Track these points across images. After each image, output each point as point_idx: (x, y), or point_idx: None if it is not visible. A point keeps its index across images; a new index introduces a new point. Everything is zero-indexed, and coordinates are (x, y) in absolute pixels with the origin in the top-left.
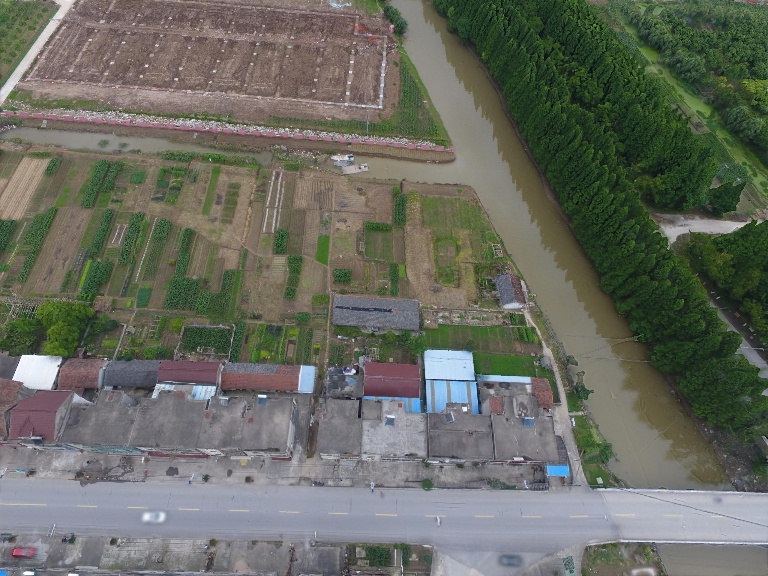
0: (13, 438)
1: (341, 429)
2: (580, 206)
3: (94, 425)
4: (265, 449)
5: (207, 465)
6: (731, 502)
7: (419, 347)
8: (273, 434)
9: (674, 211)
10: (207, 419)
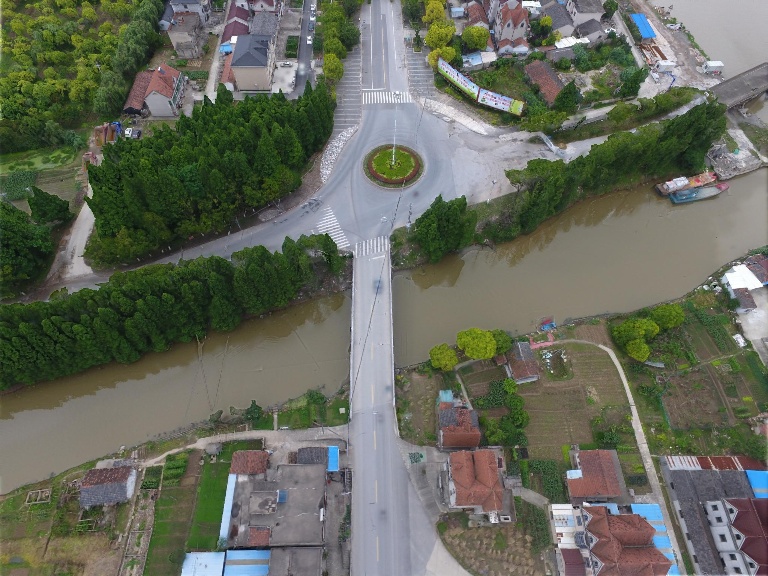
0: None
1: None
2: (1, 373)
3: None
4: None
5: None
6: (360, 299)
7: None
8: None
9: (50, 258)
10: None
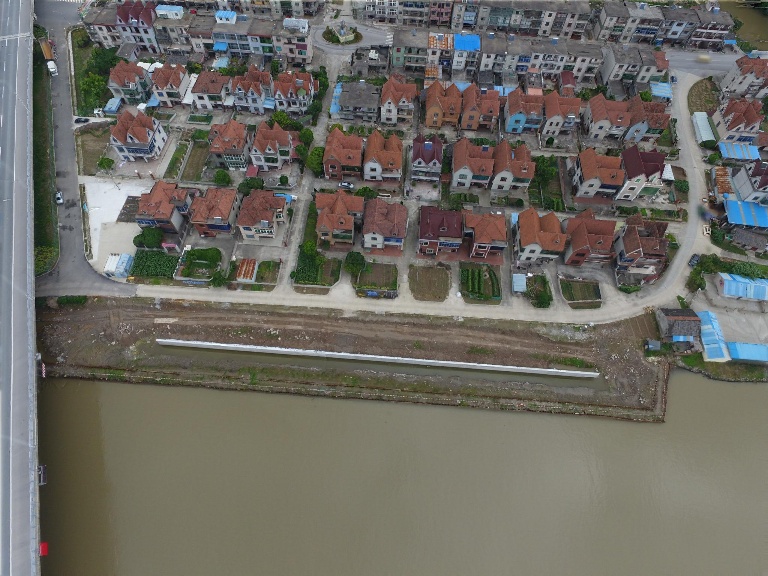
0: (457, 2)
1: (617, 9)
2: None
3: (493, 1)
4: (581, 13)
5: (537, 39)
6: None
7: (641, 1)
8: (583, 9)
9: None
10: (548, 3)
